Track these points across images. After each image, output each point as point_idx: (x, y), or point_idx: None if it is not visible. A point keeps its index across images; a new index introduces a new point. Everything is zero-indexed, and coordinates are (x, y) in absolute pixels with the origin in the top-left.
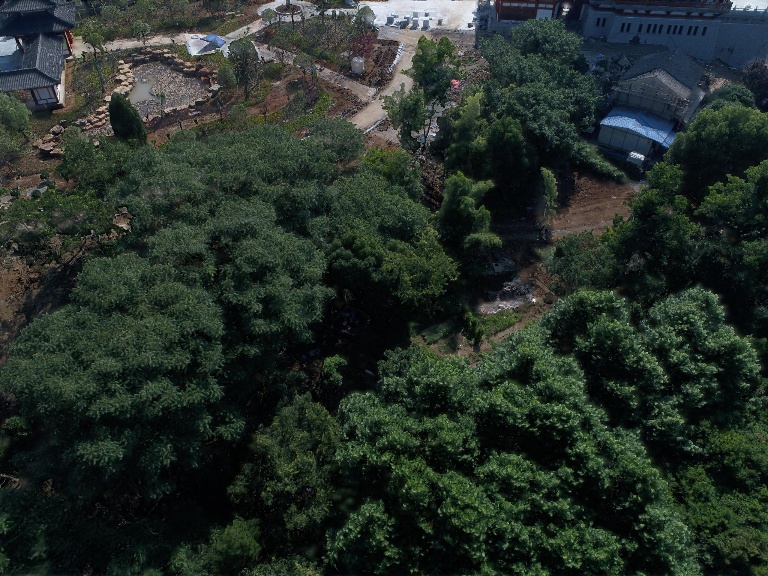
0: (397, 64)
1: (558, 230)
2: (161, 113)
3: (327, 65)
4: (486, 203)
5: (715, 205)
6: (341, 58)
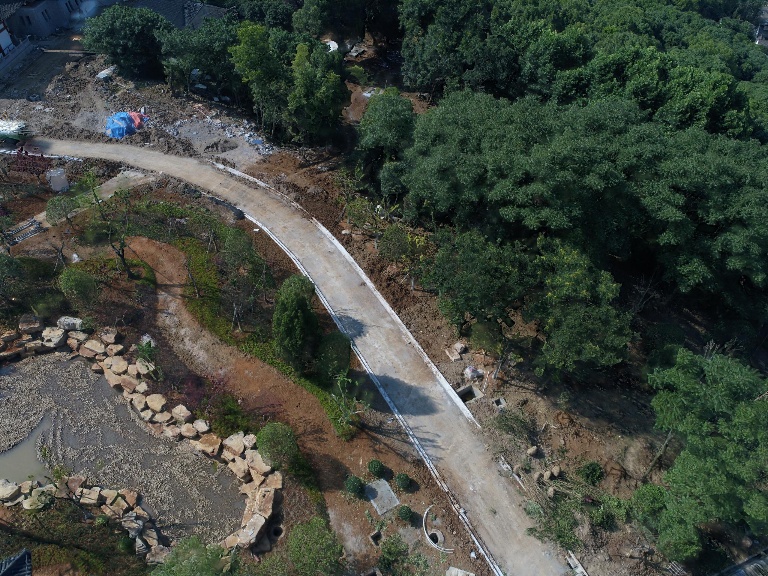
0: (55, 155)
1: (350, 116)
2: (159, 371)
3: (20, 217)
4: (322, 141)
5: (435, 0)
6: (7, 202)
